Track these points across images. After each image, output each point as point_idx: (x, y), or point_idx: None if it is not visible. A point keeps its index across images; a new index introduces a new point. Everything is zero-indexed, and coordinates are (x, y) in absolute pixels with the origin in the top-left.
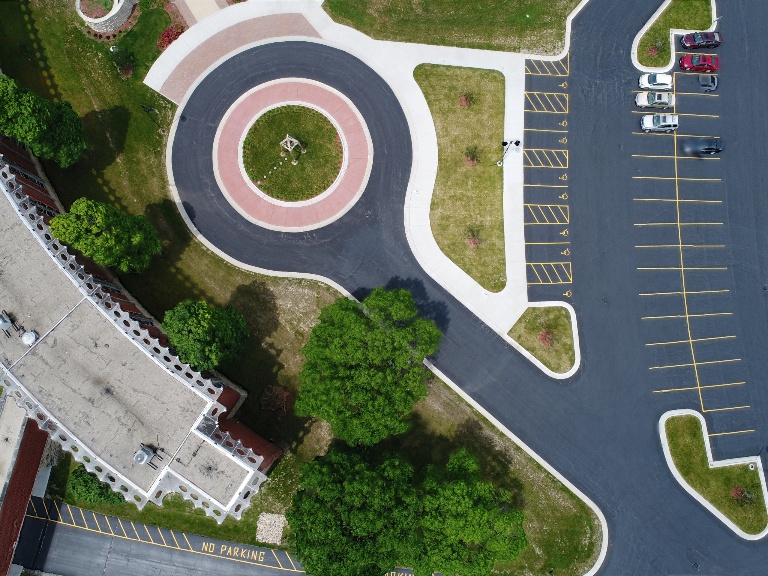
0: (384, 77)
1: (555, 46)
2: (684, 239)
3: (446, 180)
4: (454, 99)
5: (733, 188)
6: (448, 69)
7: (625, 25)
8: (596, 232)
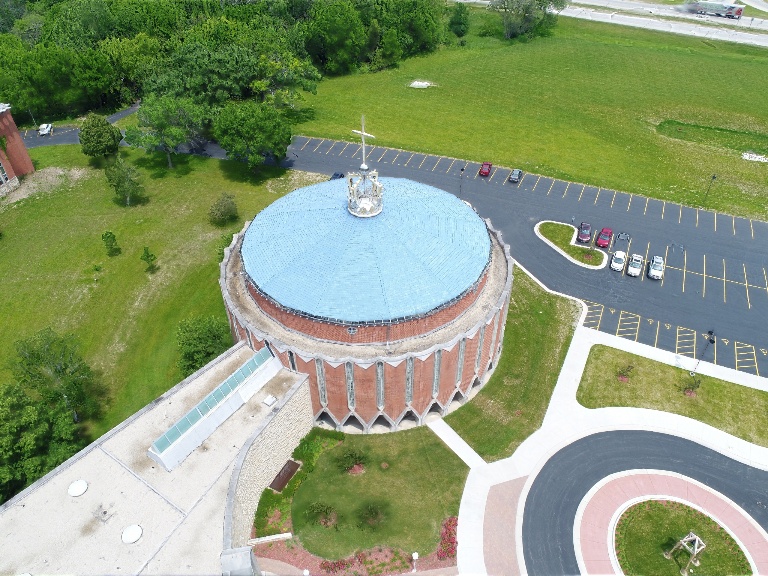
0: (587, 434)
1: (573, 305)
2: (761, 286)
3: (714, 419)
4: (620, 385)
5: (711, 251)
6: (585, 380)
7: (561, 264)
8: (760, 332)
